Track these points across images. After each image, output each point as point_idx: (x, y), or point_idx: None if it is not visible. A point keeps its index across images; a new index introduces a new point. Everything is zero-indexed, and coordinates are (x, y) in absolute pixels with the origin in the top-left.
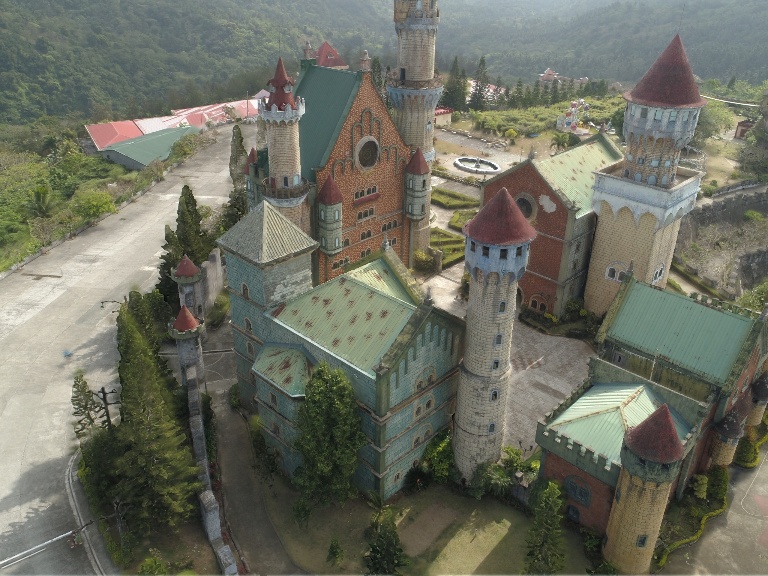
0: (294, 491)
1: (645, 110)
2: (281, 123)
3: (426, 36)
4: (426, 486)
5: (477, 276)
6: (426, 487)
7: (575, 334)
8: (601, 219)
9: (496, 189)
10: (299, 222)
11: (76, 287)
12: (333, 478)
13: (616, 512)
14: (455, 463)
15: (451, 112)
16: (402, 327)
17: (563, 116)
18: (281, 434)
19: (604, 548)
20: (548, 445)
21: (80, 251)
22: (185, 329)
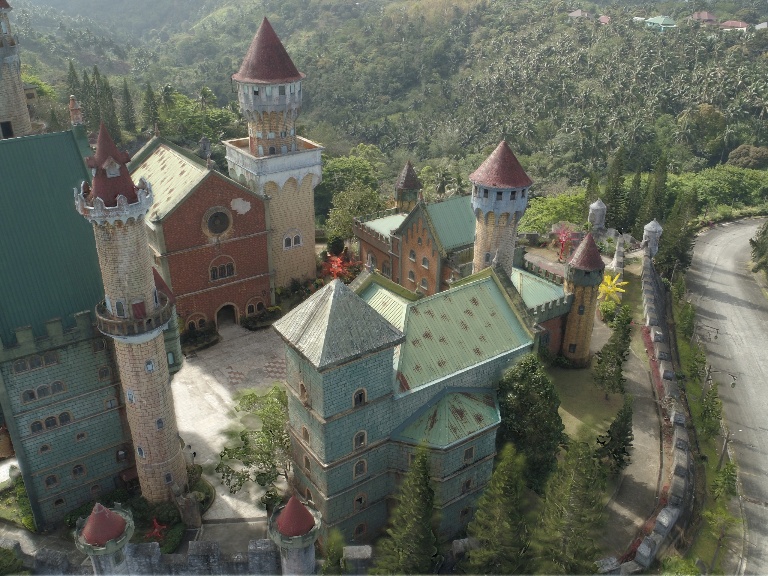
0: None
1: (283, 88)
2: None
3: (18, 70)
4: None
5: None
6: None
7: None
8: None
9: (178, 220)
10: None
11: None
12: (555, 445)
13: (583, 321)
14: None
15: None
16: (497, 298)
17: None
18: (474, 484)
19: (574, 354)
20: None
21: None
22: (312, 520)
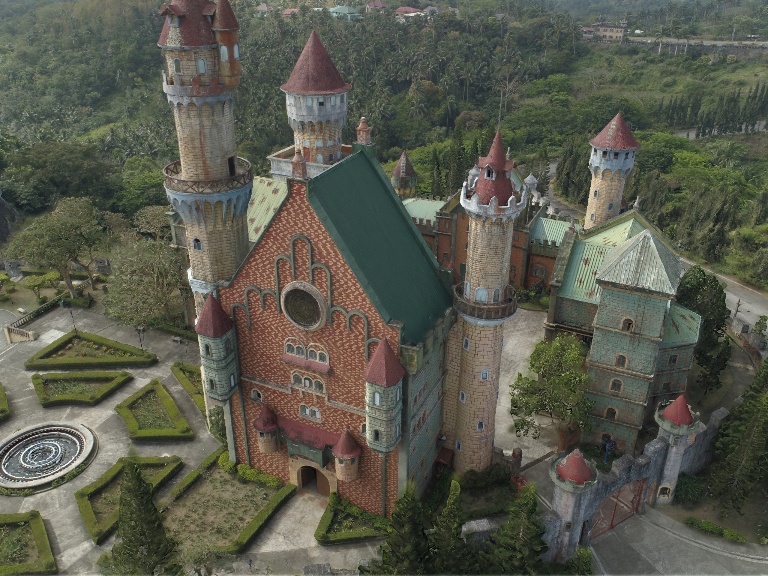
0: (686, 396)
1: None
2: None
3: None
4: None
5: None
6: None
7: None
8: None
9: None
10: None
11: None
12: None
13: None
14: None
15: None
16: None
17: None
18: None
19: None
20: None
21: None
22: None
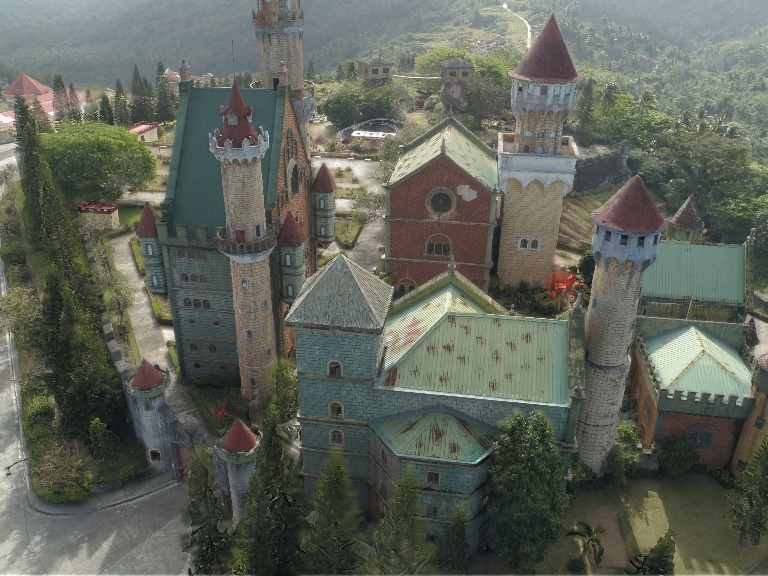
0: (466, 569)
1: (545, 88)
2: (251, 161)
3: (298, 39)
4: (574, 496)
5: (621, 269)
6: (575, 497)
7: (509, 309)
8: (508, 196)
9: (405, 190)
10: (269, 275)
11: None
12: None
13: (759, 438)
14: (582, 462)
15: (156, 126)
16: (558, 344)
17: None
18: (442, 514)
19: None
20: (673, 407)
21: None
22: (249, 447)
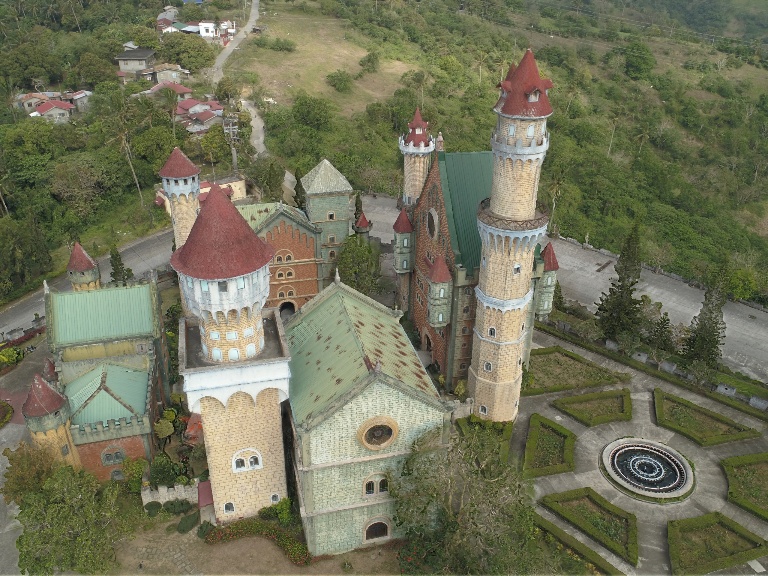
0: None
1: None
2: None
3: None
4: None
5: None
6: None
7: None
8: None
9: None
10: None
11: (572, 273)
12: None
13: None
14: None
15: None
16: None
17: None
18: None
19: None
20: None
21: (658, 286)
22: None
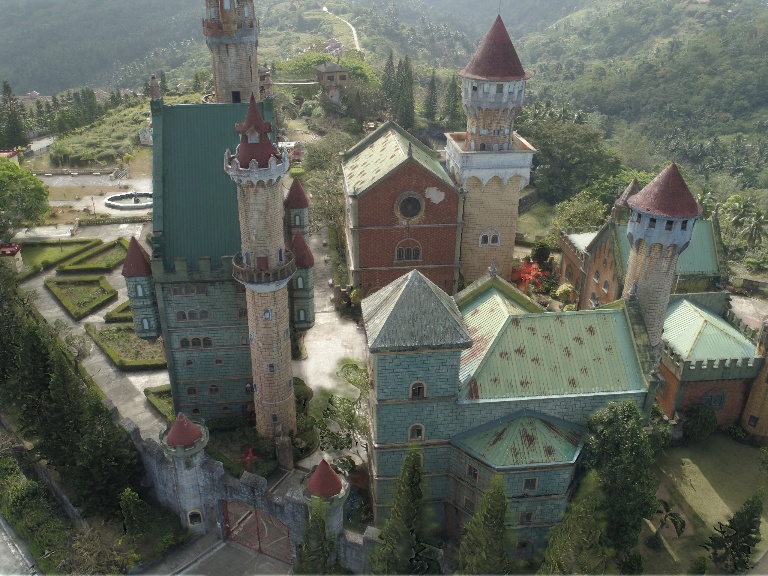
0: None
1: (501, 86)
2: None
3: None
4: None
5: (664, 253)
6: None
7: None
8: (468, 195)
9: (373, 198)
10: None
11: None
12: (647, 511)
13: None
14: None
15: (16, 153)
16: (620, 333)
17: (142, 129)
18: (536, 518)
19: (754, 428)
20: (695, 376)
21: None
22: (338, 488)
